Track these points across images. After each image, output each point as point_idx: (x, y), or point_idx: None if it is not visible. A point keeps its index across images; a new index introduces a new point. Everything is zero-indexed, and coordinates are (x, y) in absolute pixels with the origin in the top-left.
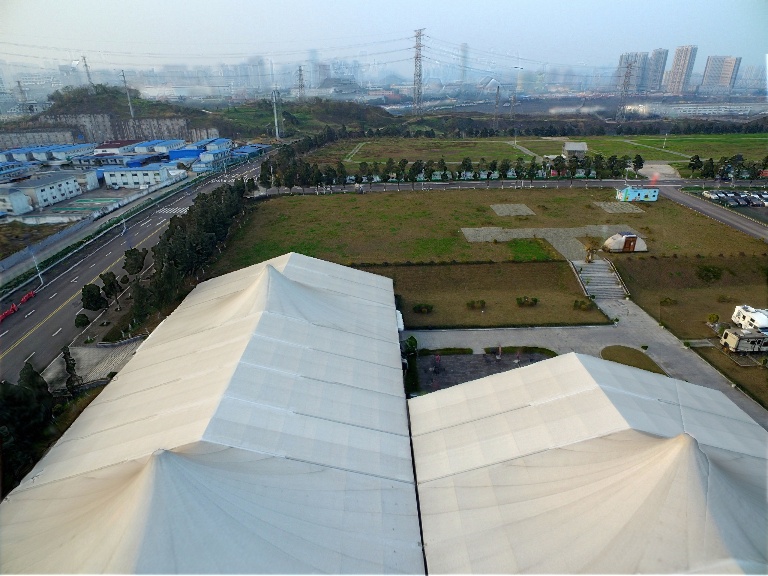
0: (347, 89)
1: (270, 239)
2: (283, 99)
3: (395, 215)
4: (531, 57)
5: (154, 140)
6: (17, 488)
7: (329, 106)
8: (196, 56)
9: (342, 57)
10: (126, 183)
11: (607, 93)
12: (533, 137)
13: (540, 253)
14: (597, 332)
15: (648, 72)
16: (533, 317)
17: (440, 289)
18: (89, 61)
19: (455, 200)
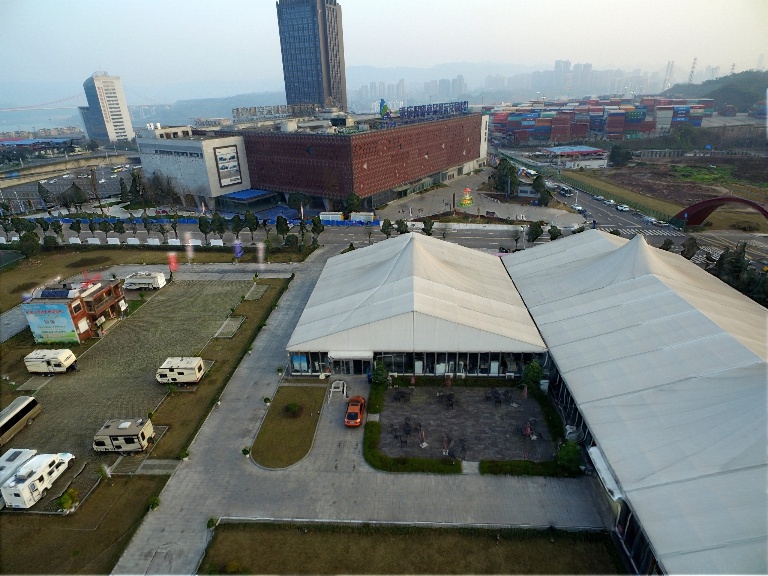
0: None
1: None
2: None
3: None
4: None
5: None
6: (766, 309)
7: None
8: None
9: None
10: None
11: None
12: None
13: None
14: (268, 504)
15: None
16: (349, 556)
17: None
18: None
19: None
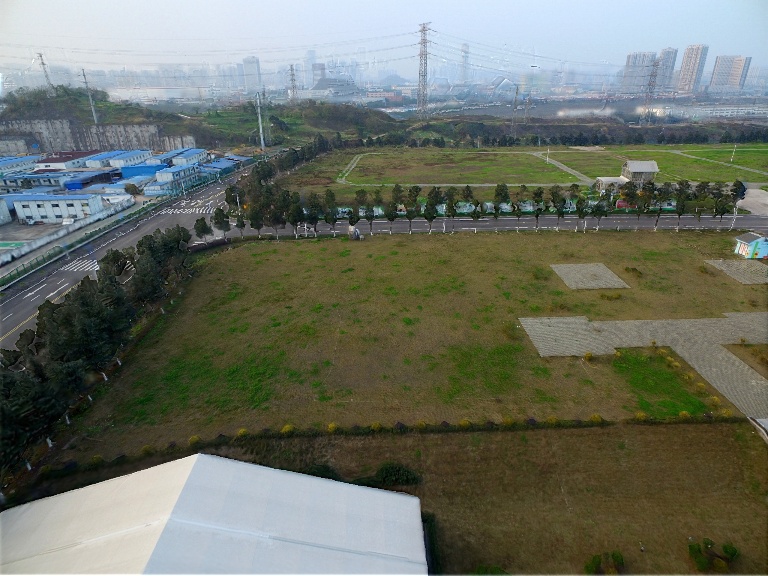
0: (344, 90)
1: (200, 347)
2: (273, 102)
3: (409, 287)
4: (549, 54)
5: (115, 151)
6: None
7: (323, 110)
8: (173, 53)
9: (338, 54)
10: (45, 216)
11: (630, 94)
12: (561, 147)
13: (683, 392)
14: None
15: (676, 71)
16: None
17: (512, 493)
18: (51, 59)
19: (496, 255)
